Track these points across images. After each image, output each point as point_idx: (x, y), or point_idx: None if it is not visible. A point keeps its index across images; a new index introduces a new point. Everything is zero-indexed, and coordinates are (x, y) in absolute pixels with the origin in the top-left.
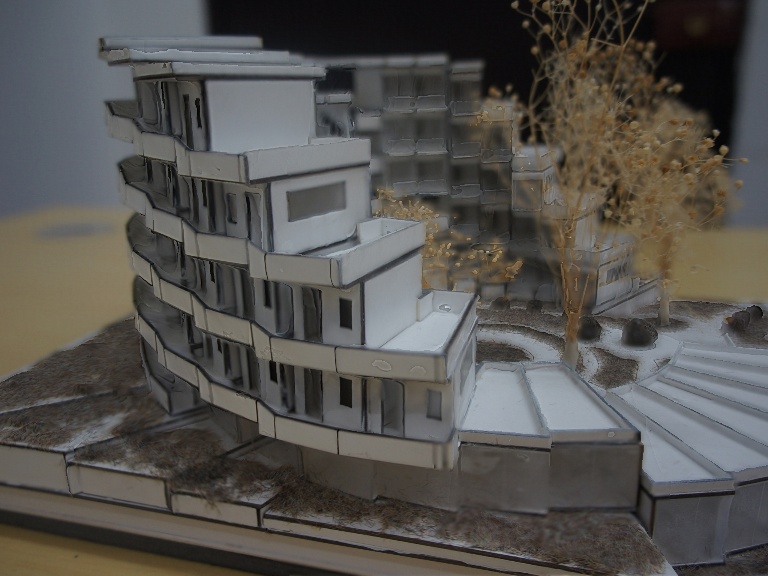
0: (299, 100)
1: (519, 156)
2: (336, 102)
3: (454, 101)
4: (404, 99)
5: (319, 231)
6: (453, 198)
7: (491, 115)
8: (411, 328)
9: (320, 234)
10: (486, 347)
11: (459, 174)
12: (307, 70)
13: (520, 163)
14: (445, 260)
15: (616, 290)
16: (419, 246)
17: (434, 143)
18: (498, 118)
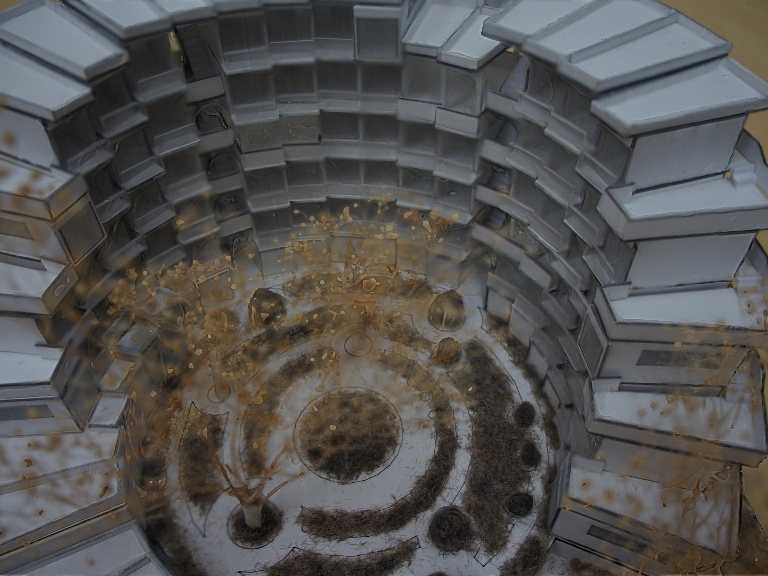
0: (37, 129)
1: (737, 285)
2: (450, 63)
3: (597, 149)
4: (535, 104)
5: (6, 243)
6: (551, 264)
7: (608, 209)
8: (27, 356)
9: (8, 245)
10: (376, 427)
11: (578, 243)
12: (34, 108)
13: (601, 302)
14: (538, 316)
15: (622, 555)
16: (38, 313)
17: (559, 183)
18: (613, 221)
